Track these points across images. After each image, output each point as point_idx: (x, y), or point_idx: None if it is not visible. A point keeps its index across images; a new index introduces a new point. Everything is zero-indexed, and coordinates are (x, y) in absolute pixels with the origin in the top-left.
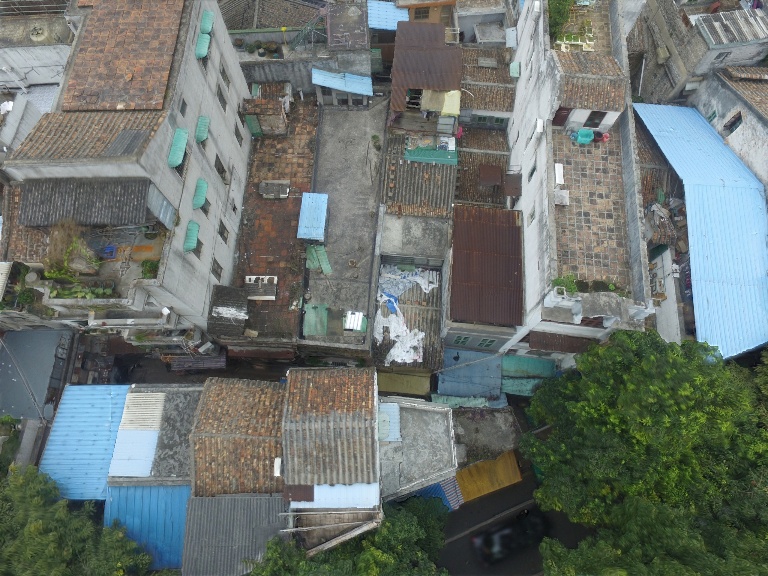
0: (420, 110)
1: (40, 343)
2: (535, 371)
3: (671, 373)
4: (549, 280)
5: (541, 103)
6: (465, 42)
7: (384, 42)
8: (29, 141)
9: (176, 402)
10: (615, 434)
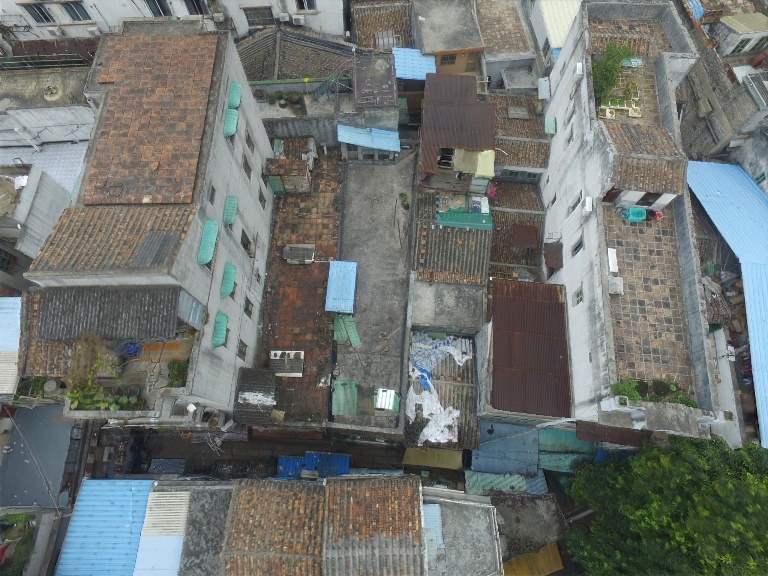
0: None
1: (54, 420)
2: (574, 445)
3: (754, 507)
4: (607, 382)
5: (587, 176)
6: (492, 88)
7: (409, 90)
8: (49, 245)
9: (202, 502)
10: (681, 554)
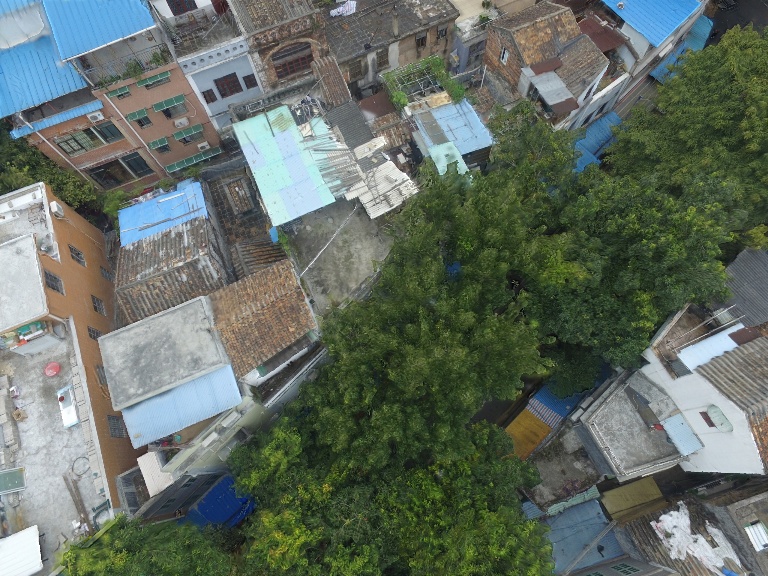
0: None
1: None
2: None
3: None
4: None
5: None
6: None
7: None
8: None
9: None
10: None
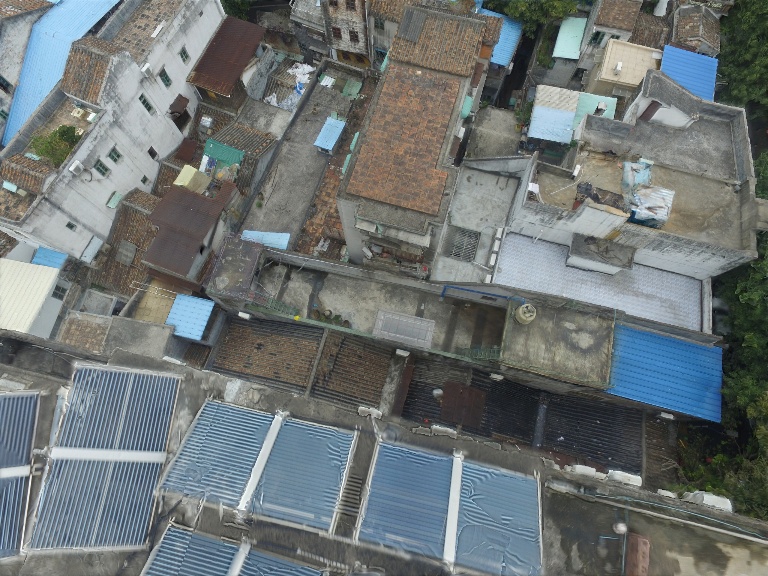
0: None
1: None
2: None
3: None
4: None
5: None
6: None
7: None
8: (475, 45)
9: None
10: None
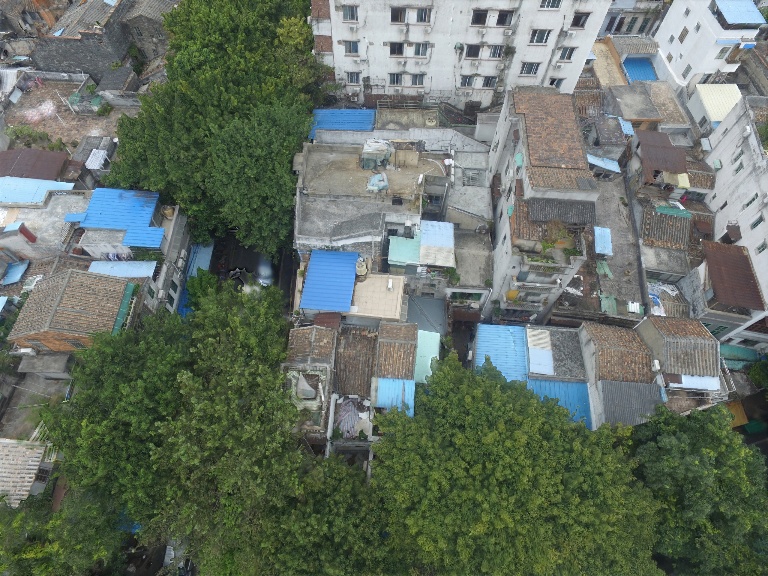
0: (662, 183)
1: (424, 306)
2: (743, 356)
3: None
4: None
5: (763, 184)
6: None
7: None
8: (533, 179)
9: (557, 337)
10: None
